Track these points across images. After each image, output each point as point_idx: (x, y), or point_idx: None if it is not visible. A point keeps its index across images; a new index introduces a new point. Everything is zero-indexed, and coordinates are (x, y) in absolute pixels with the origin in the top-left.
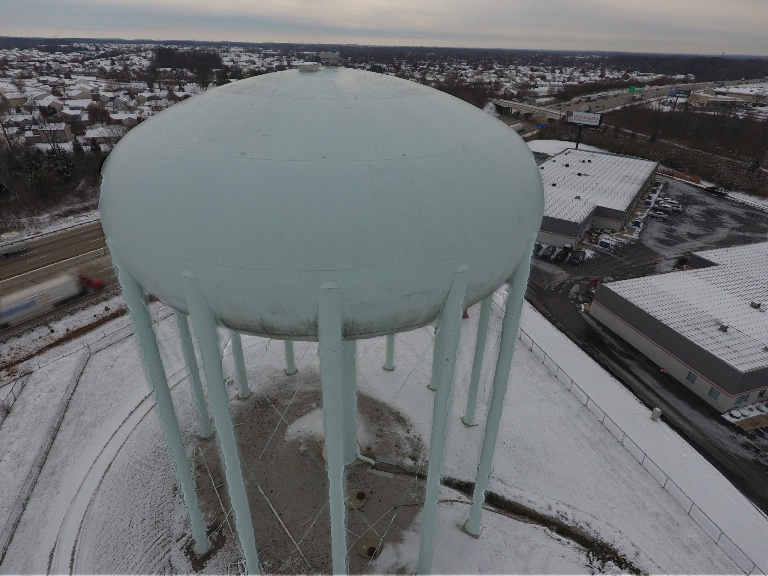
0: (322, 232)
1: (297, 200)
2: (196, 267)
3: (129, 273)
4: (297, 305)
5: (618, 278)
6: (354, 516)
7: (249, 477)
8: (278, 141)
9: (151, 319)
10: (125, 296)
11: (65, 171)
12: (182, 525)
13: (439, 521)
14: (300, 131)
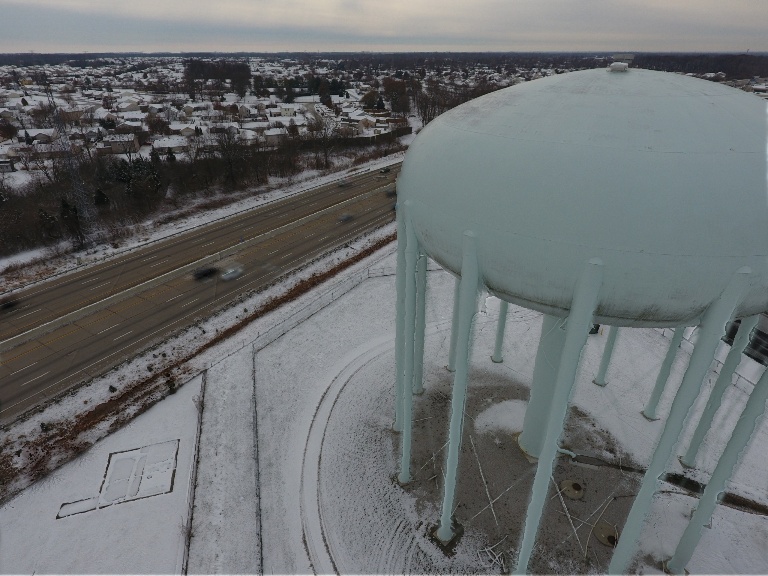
0: (747, 219)
1: (718, 190)
2: (607, 255)
3: (478, 265)
4: (702, 290)
5: None
6: (578, 506)
7: (458, 469)
8: (673, 135)
9: (478, 309)
10: (466, 287)
11: (155, 180)
12: (415, 514)
13: (664, 511)
14: (686, 126)
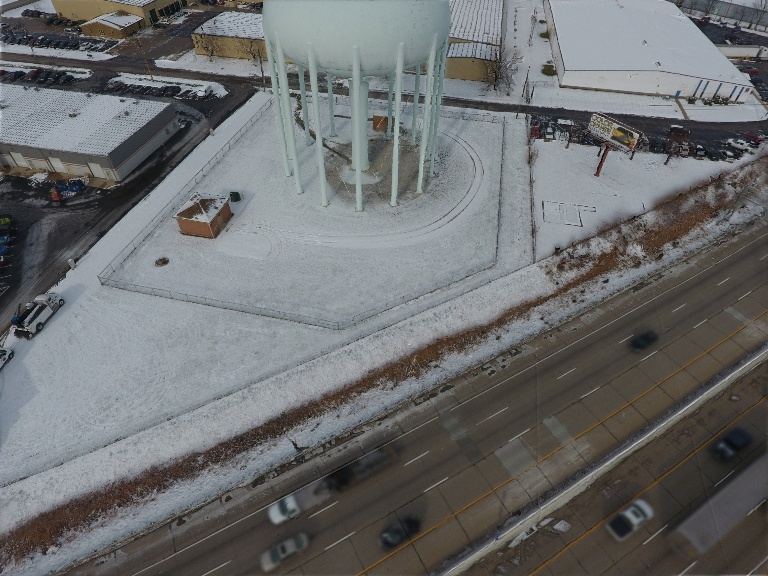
0: None
1: None
2: None
3: None
4: None
5: (23, 198)
6: (371, 149)
7: (405, 170)
8: None
9: None
10: None
11: None
12: None
13: None
14: None
